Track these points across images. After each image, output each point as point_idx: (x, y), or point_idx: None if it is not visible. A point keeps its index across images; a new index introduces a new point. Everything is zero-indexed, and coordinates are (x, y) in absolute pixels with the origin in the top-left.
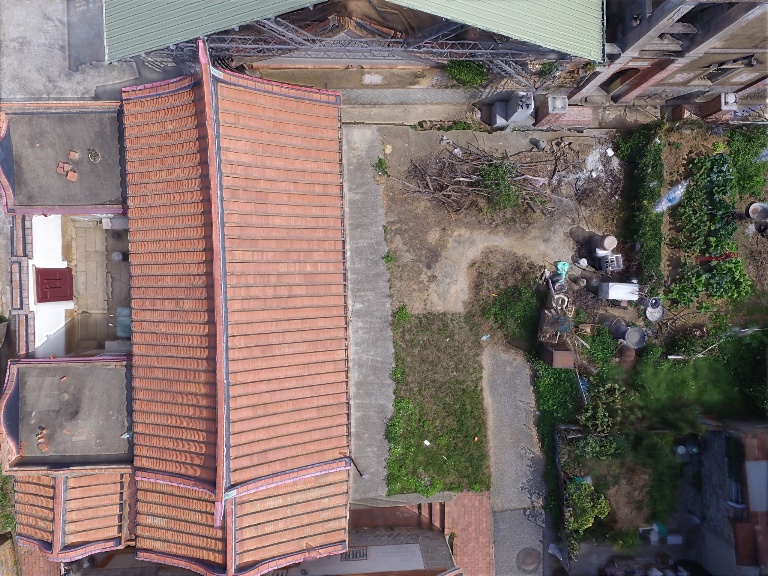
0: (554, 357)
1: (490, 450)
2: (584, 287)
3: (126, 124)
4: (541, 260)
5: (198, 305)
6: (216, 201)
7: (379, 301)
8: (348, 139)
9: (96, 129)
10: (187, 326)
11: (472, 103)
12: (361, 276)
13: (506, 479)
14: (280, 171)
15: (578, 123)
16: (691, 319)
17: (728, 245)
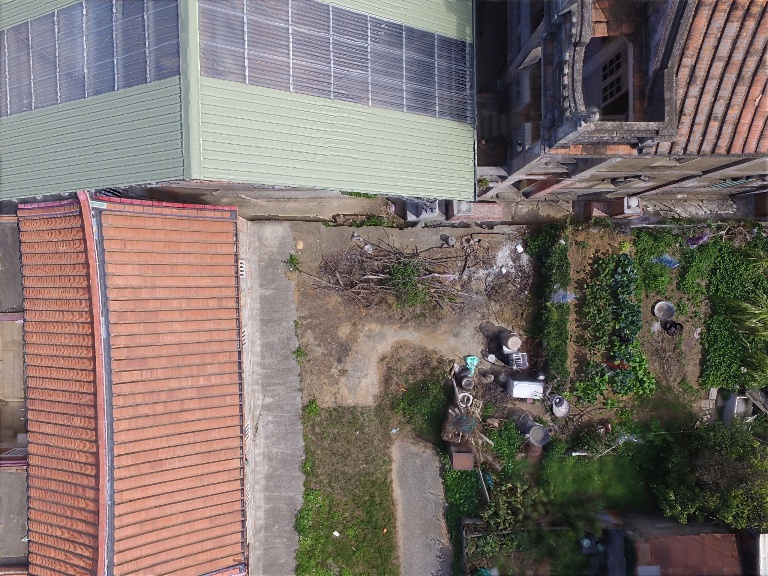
0: (454, 459)
1: (399, 541)
2: (493, 381)
3: (22, 240)
4: (451, 354)
5: (87, 423)
6: (98, 328)
7: (289, 395)
8: (259, 236)
9: None
10: (77, 442)
11: (385, 197)
12: (271, 371)
13: (415, 569)
14: (171, 289)
15: (489, 219)
16: (597, 415)
17: (632, 344)
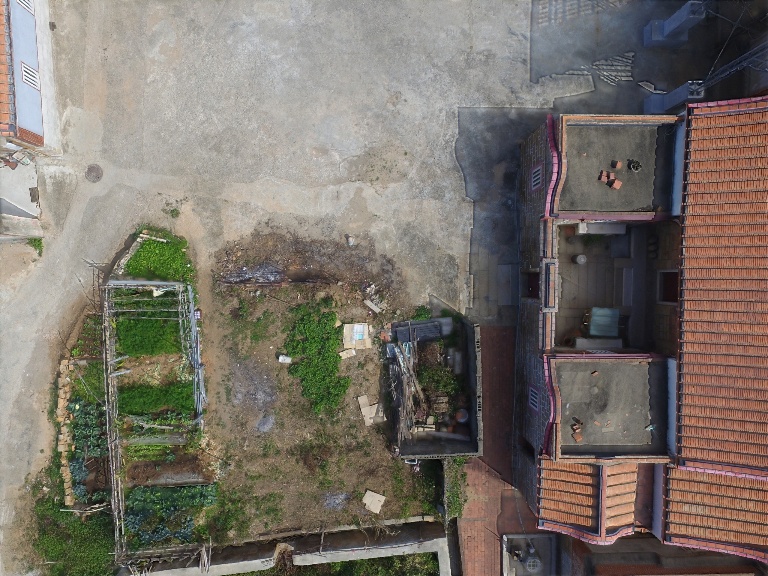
0: None
1: None
2: None
3: (691, 138)
4: None
5: None
6: None
7: None
8: None
9: (637, 141)
10: (760, 327)
11: None
12: None
13: None
14: None
15: None
16: None
17: None
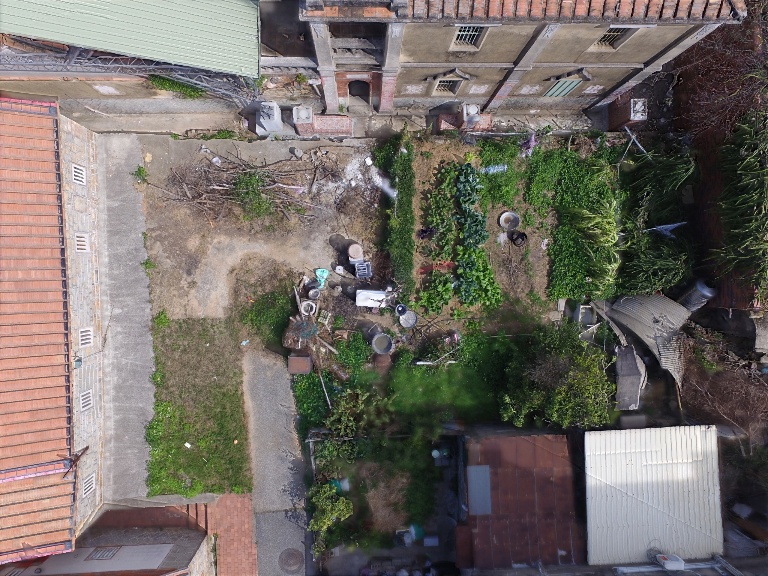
0: (289, 363)
1: (251, 453)
2: (343, 294)
3: None
4: (301, 267)
5: None
6: None
7: (138, 306)
8: (107, 148)
9: None
10: None
11: (238, 112)
12: (120, 282)
13: (267, 481)
14: None
15: (338, 133)
16: (445, 326)
17: (475, 253)
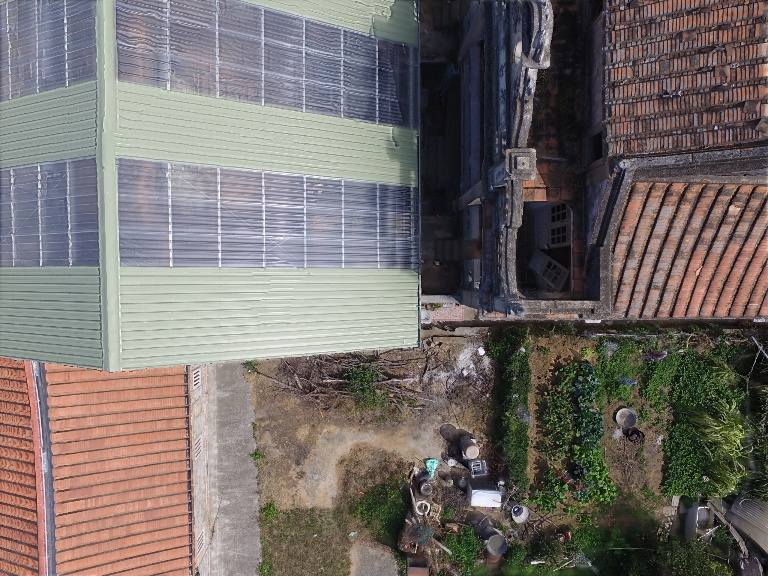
0: (408, 573)
1: None
2: (453, 484)
3: None
4: (411, 457)
5: (30, 552)
6: (39, 465)
7: (246, 498)
8: None
9: None
10: (21, 570)
11: None
12: (228, 473)
13: None
14: (118, 415)
15: None
16: (558, 521)
17: (592, 453)
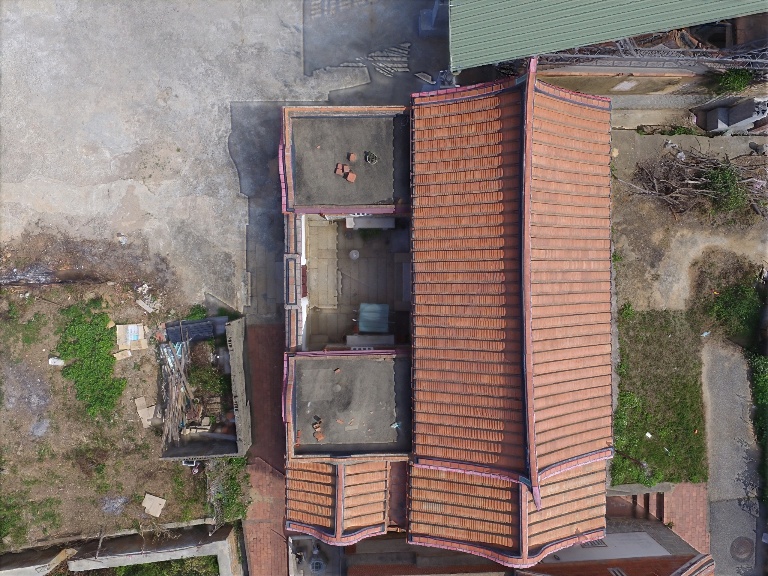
0: None
1: (708, 442)
2: None
3: (415, 128)
4: (759, 260)
5: (494, 300)
6: (529, 202)
7: None
8: None
9: (373, 132)
10: (480, 320)
11: (689, 108)
12: None
13: (722, 470)
14: (566, 173)
15: None
16: None
17: None
